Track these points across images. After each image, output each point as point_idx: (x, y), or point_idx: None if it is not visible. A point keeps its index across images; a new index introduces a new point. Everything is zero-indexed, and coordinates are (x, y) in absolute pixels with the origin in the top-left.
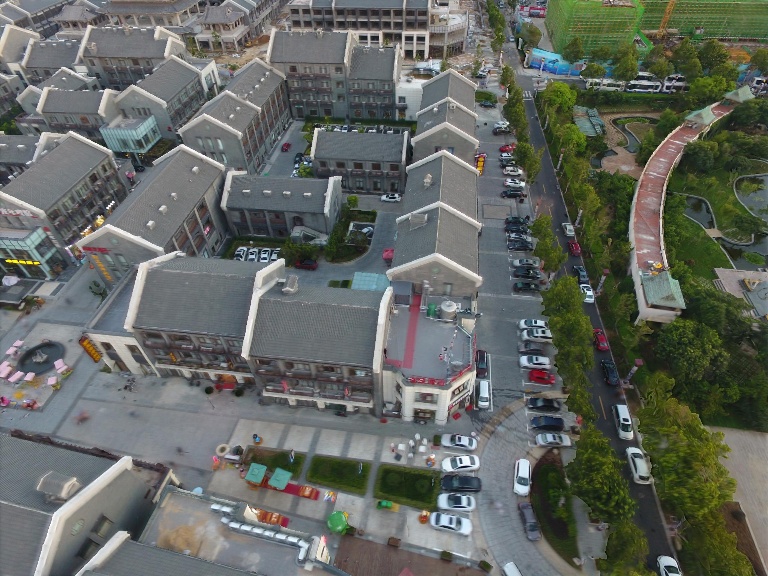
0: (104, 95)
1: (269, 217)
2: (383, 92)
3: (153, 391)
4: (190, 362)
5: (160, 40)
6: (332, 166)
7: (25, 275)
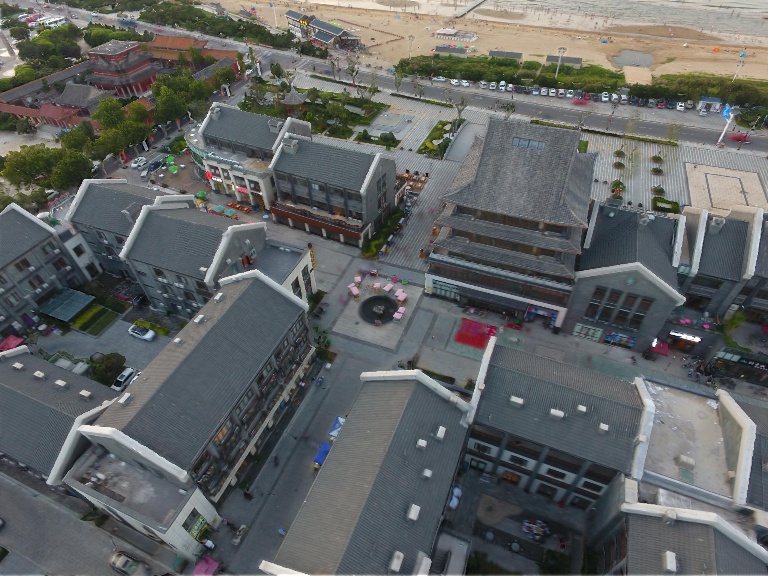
0: None
1: None
2: None
3: None
4: None
5: None
6: None
7: None
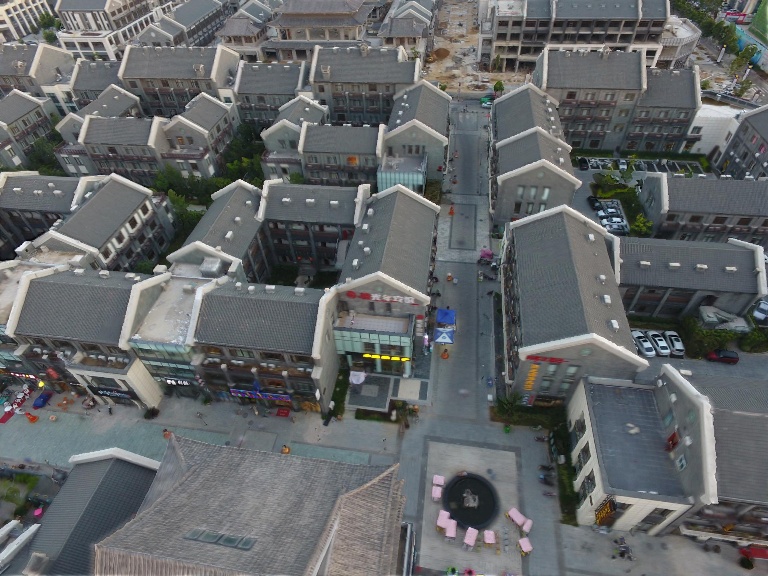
0: (380, 132)
1: (667, 295)
2: (677, 121)
3: (658, 559)
4: (741, 531)
5: (404, 62)
6: (684, 220)
7: (373, 369)
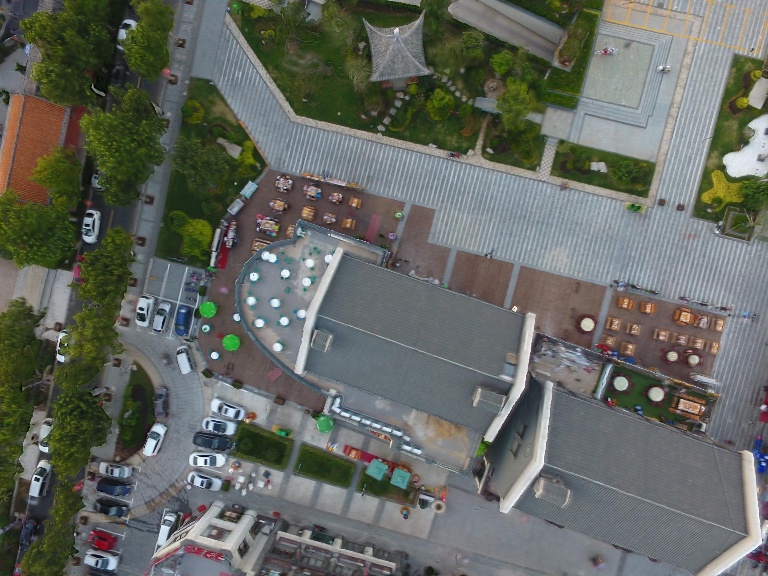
0: None
1: None
2: None
3: None
4: None
5: None
6: None
7: None
